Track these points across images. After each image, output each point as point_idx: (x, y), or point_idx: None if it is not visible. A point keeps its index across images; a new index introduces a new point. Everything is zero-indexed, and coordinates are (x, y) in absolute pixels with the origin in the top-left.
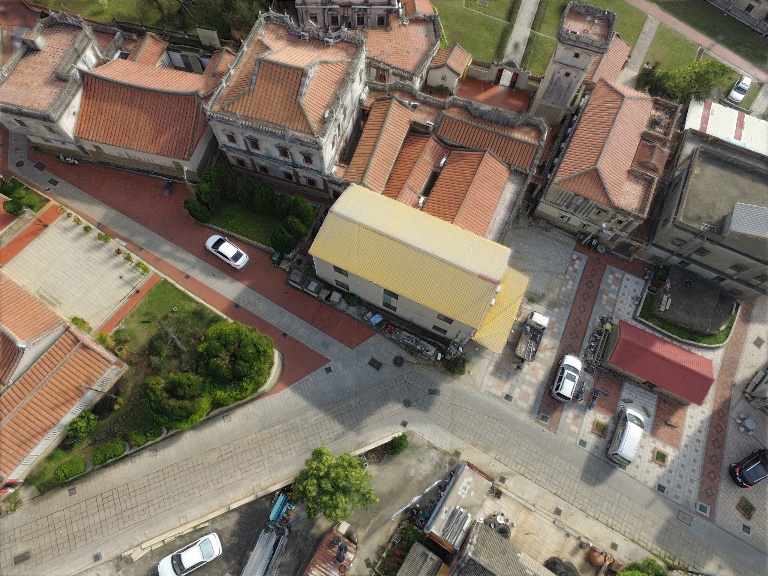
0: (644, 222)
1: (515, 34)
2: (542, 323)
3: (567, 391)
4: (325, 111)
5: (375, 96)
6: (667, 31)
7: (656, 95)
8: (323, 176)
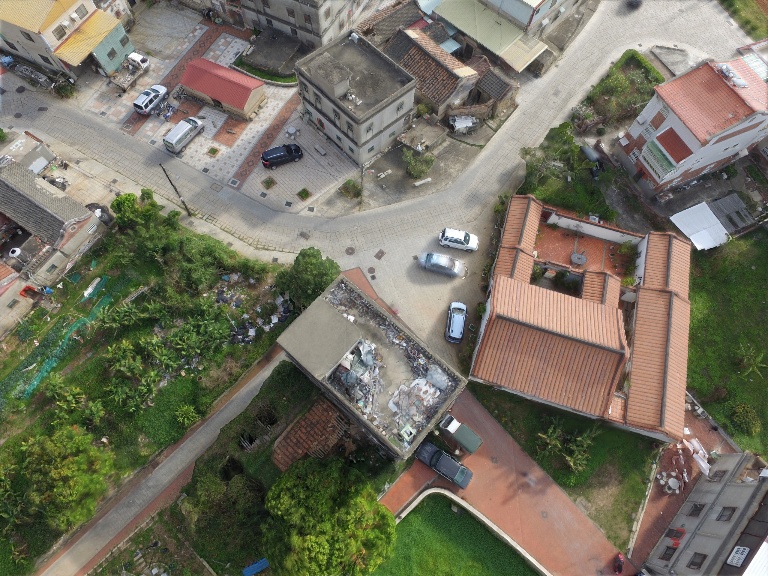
0: None
1: None
2: (135, 59)
3: (139, 101)
4: None
5: None
6: None
7: None
8: None
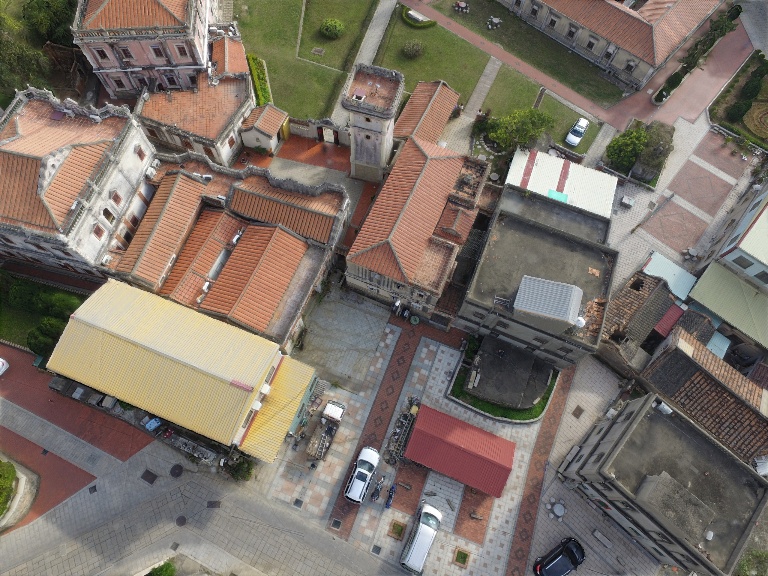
0: (456, 290)
1: None
2: (334, 416)
3: (355, 494)
4: None
5: (167, 169)
6: (509, 72)
7: (493, 142)
8: (91, 267)
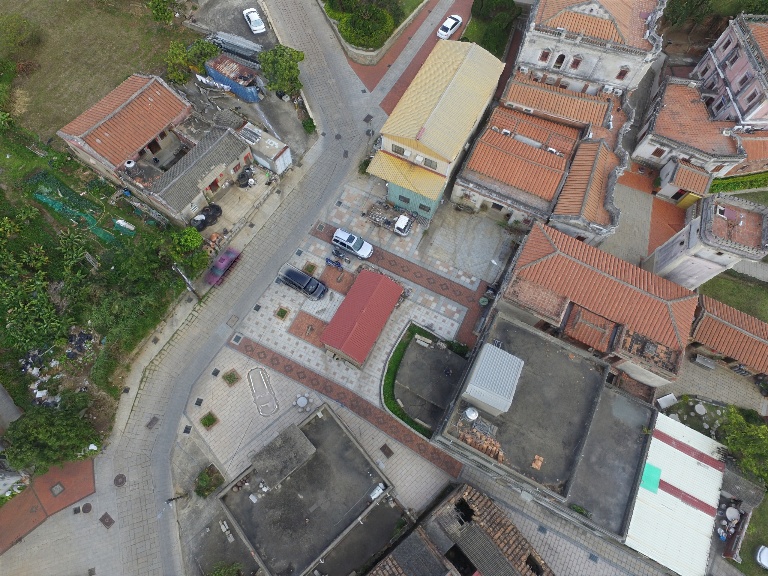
0: None
1: None
2: (399, 222)
3: (339, 234)
4: None
5: (614, 100)
6: None
7: None
8: None
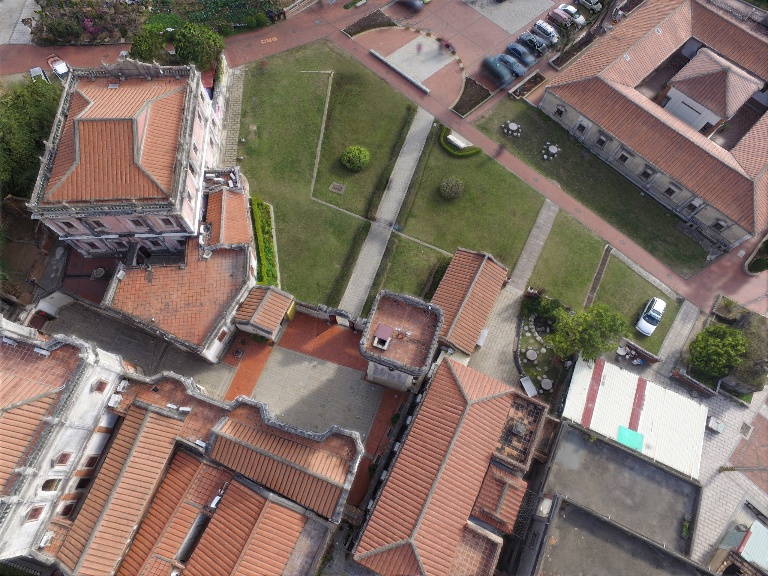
0: None
1: (371, 237)
2: None
3: None
4: (3, 491)
5: (136, 392)
6: (567, 222)
7: (545, 324)
8: None
